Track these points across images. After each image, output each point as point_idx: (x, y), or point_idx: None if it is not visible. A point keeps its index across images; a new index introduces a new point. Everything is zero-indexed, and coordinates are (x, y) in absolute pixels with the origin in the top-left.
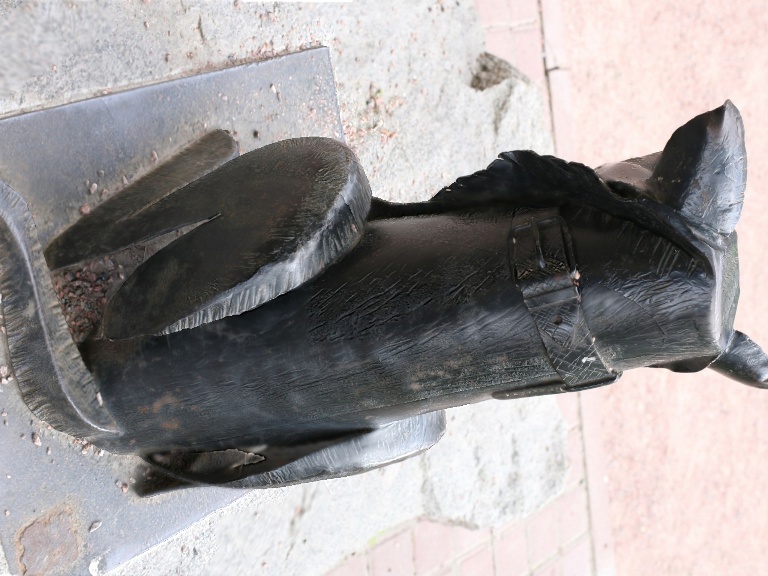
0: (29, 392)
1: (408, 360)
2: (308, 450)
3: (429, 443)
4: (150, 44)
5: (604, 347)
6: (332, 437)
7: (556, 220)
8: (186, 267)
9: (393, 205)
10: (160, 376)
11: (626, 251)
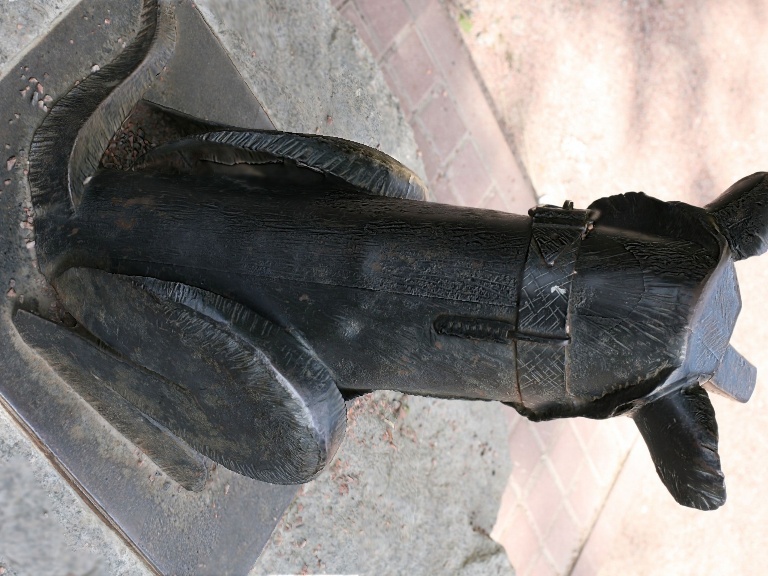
0: (48, 126)
1: (390, 237)
2: None
3: (315, 418)
4: None
5: (579, 286)
6: (253, 307)
7: None
8: None
9: None
10: (156, 185)
11: None
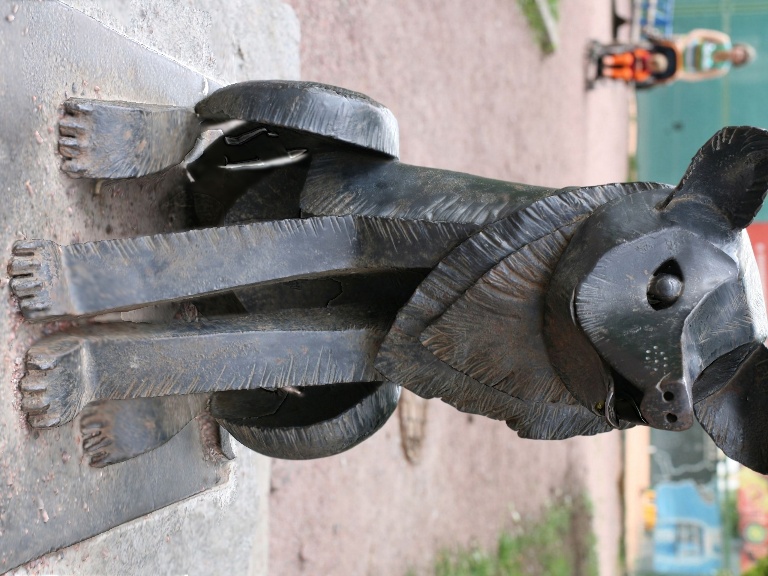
0: None
1: None
2: None
3: None
4: (113, 568)
5: None
6: None
7: None
8: None
9: None
10: None
11: None
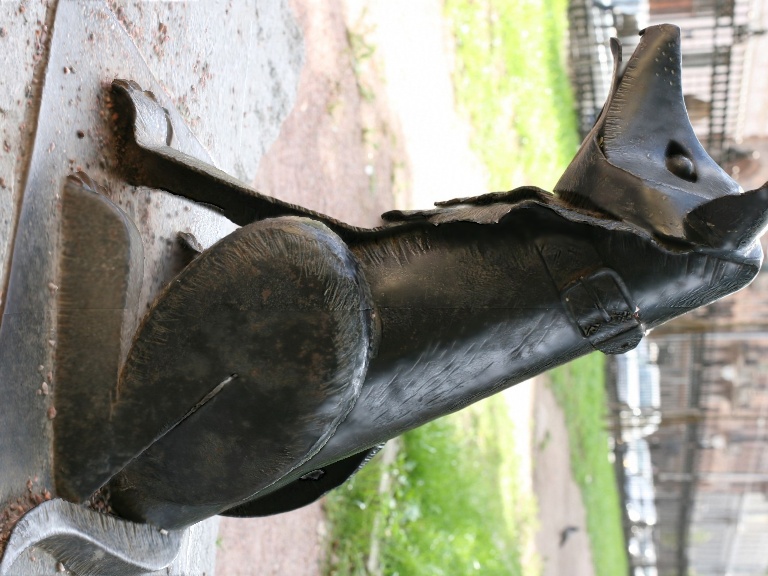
0: None
1: None
2: (364, 452)
3: None
4: None
5: None
6: None
7: (605, 273)
8: (234, 441)
9: (361, 233)
10: None
11: (677, 276)
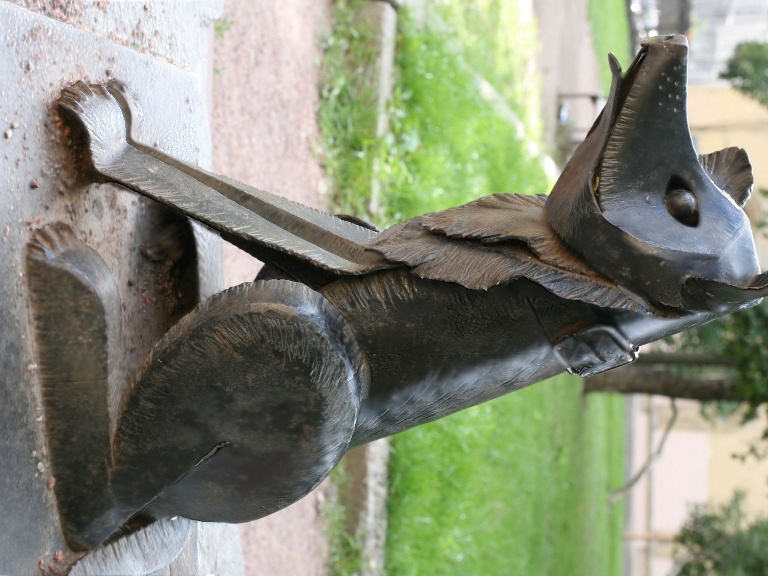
0: None
1: None
2: None
3: None
4: None
5: None
6: None
7: None
8: (233, 488)
9: None
10: None
11: None
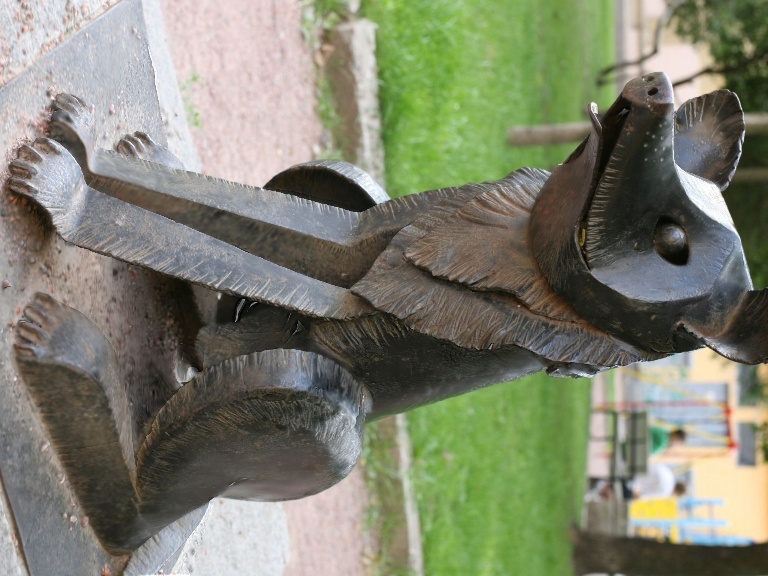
0: None
1: None
2: None
3: None
4: None
5: None
6: None
7: None
8: None
9: None
10: None
11: None
